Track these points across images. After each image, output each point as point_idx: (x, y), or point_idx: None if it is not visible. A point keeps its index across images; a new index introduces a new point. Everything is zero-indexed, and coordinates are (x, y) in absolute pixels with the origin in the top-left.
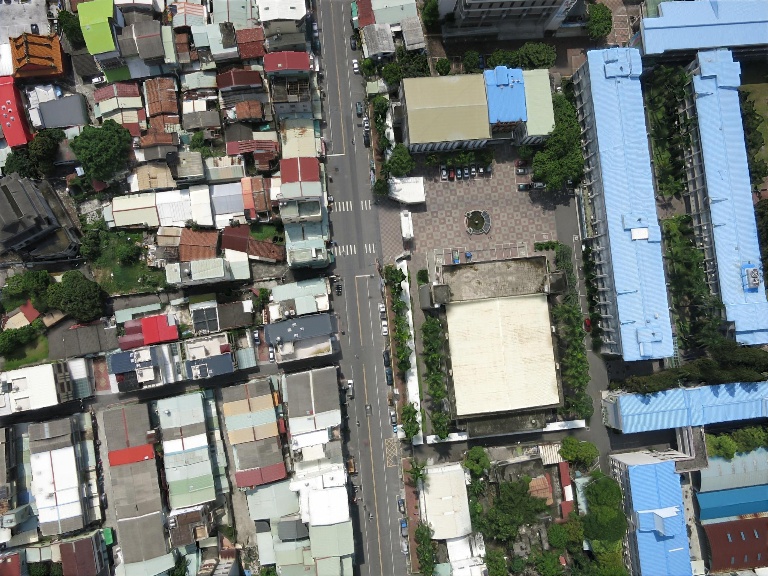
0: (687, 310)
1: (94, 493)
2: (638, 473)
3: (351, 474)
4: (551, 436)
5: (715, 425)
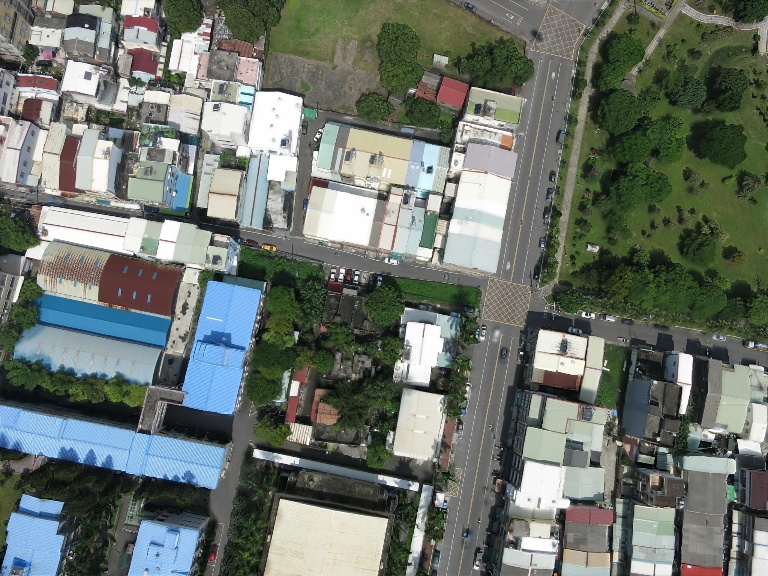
0: (96, 537)
1: (736, 537)
2: (225, 406)
3: (499, 475)
4: (292, 447)
5: (115, 404)
